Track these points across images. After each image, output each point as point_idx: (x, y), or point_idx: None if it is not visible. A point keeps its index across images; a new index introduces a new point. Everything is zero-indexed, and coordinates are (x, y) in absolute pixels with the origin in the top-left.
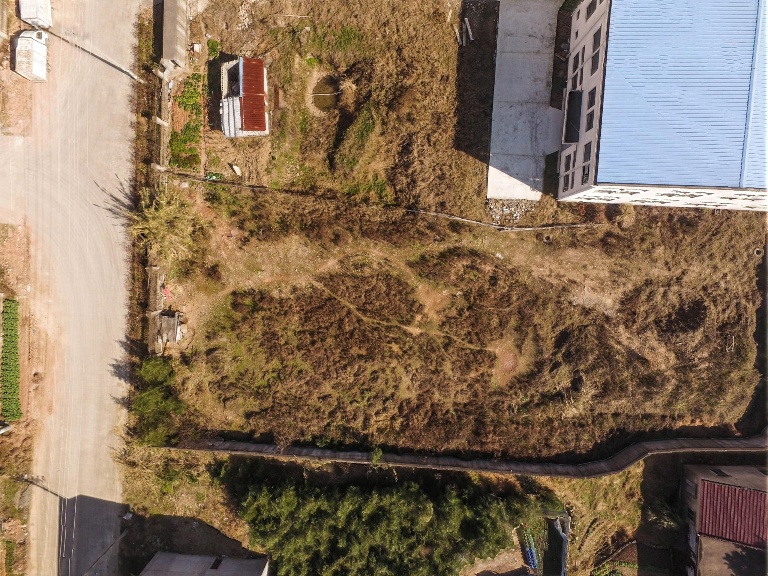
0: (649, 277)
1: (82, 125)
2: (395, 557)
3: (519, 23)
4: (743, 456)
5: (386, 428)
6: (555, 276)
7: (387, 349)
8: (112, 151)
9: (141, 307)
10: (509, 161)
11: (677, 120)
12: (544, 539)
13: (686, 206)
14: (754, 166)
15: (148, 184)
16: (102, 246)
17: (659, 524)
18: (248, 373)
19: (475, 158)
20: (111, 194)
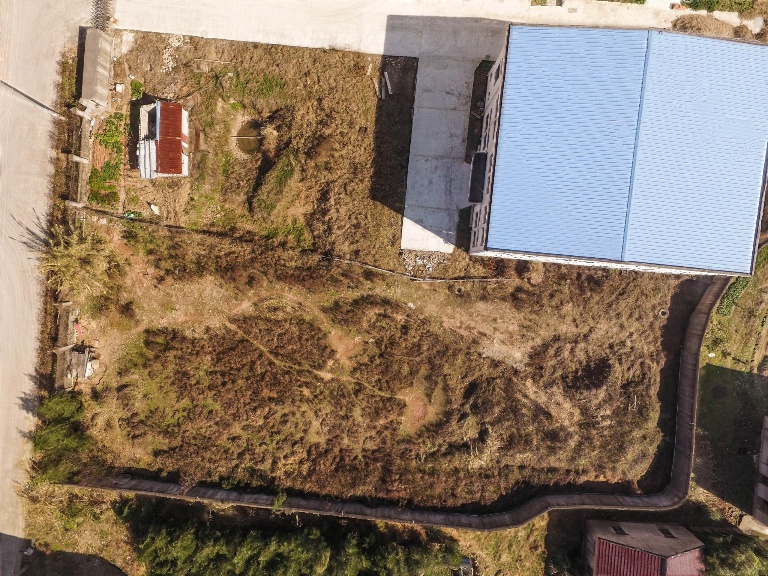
0: (557, 333)
1: (1, 158)
2: None
3: (437, 80)
4: (645, 513)
5: (294, 472)
6: (465, 328)
7: (298, 393)
8: (30, 185)
9: (52, 341)
10: (423, 213)
11: (564, 192)
12: None
13: None
14: (635, 240)
15: (65, 219)
16: (16, 279)
17: None
18: (158, 411)
19: (390, 209)
20: (27, 227)
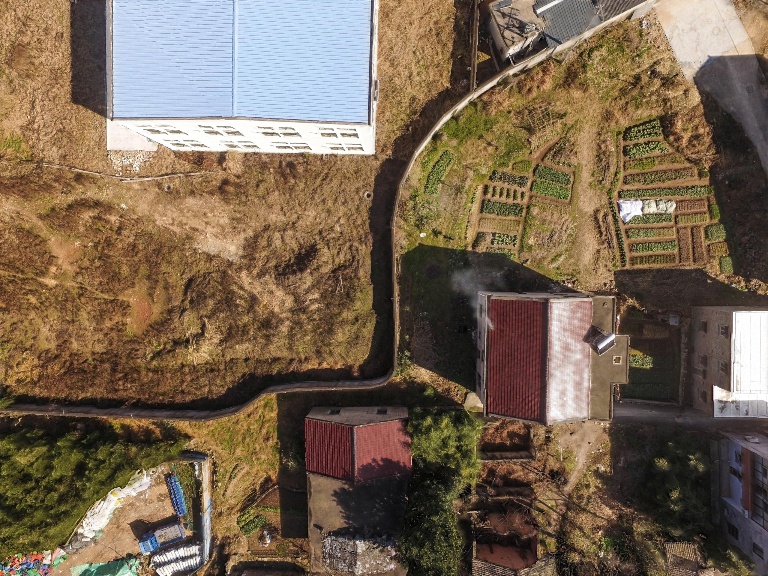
0: (267, 223)
1: None
2: (16, 503)
3: None
4: (371, 397)
5: (26, 379)
6: (177, 224)
7: (25, 301)
8: None
9: None
10: None
11: (175, 54)
12: (191, 486)
13: (292, 152)
14: (244, 96)
15: None
16: None
17: (287, 466)
18: None
19: (94, 111)
20: None
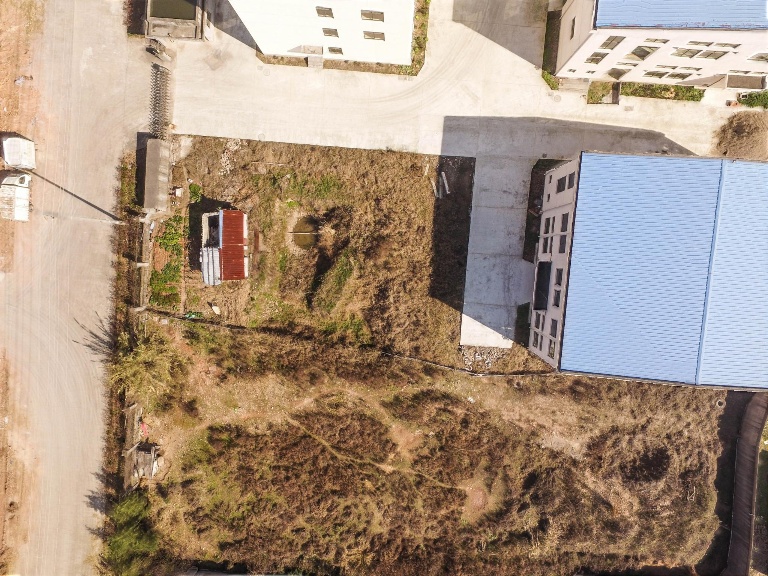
0: (615, 424)
1: (63, 263)
2: None
3: (494, 179)
4: None
5: (357, 562)
6: (525, 421)
7: (360, 485)
8: (93, 289)
9: (118, 441)
10: (482, 310)
11: (637, 316)
12: None
13: None
14: (709, 364)
15: (128, 322)
16: (81, 381)
17: None
18: (223, 505)
19: (449, 306)
20: (91, 331)
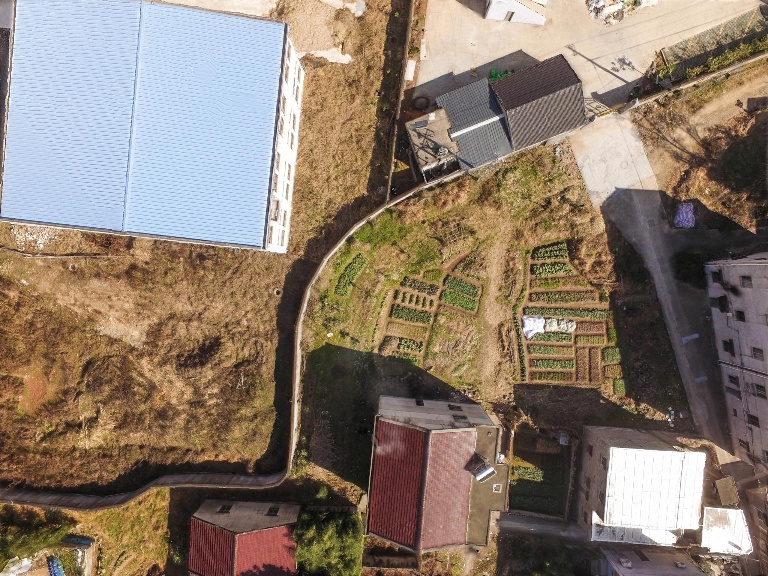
0: (173, 311)
1: None
2: None
3: None
4: (266, 492)
5: None
6: (79, 305)
7: None
8: None
9: None
10: None
11: (68, 161)
12: (75, 571)
13: None
14: (136, 211)
15: None
16: None
17: (173, 559)
18: None
19: None
20: None
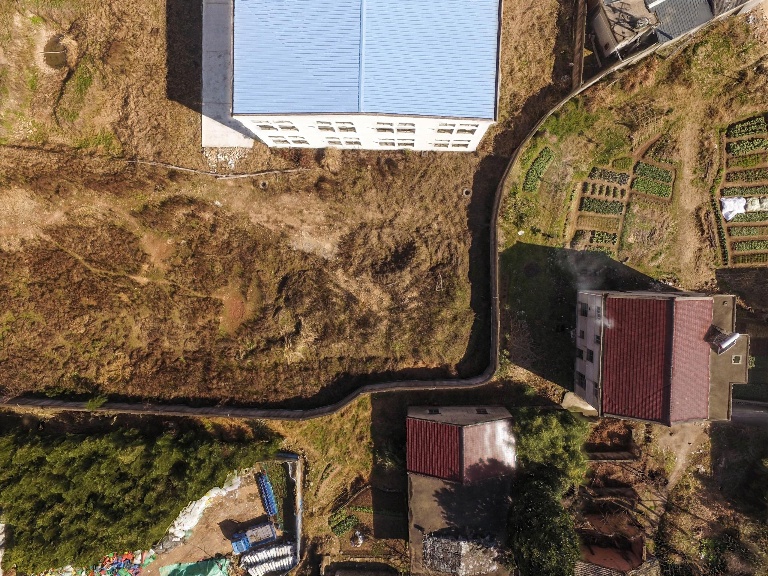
0: (364, 220)
1: None
2: (113, 503)
3: None
4: (467, 397)
5: (117, 377)
6: (273, 222)
7: (117, 299)
8: None
9: None
10: (221, 110)
11: (299, 49)
12: (282, 486)
13: (391, 148)
14: (371, 91)
15: None
16: None
17: (383, 466)
18: None
19: (189, 108)
20: None
